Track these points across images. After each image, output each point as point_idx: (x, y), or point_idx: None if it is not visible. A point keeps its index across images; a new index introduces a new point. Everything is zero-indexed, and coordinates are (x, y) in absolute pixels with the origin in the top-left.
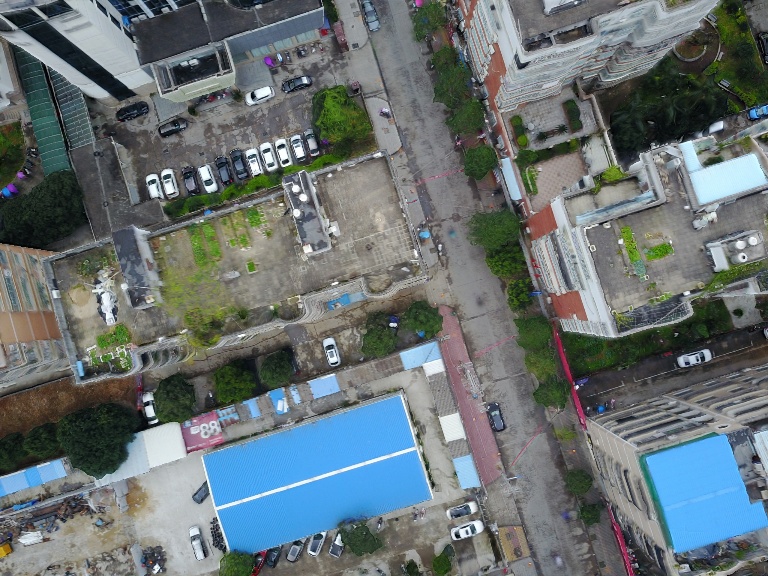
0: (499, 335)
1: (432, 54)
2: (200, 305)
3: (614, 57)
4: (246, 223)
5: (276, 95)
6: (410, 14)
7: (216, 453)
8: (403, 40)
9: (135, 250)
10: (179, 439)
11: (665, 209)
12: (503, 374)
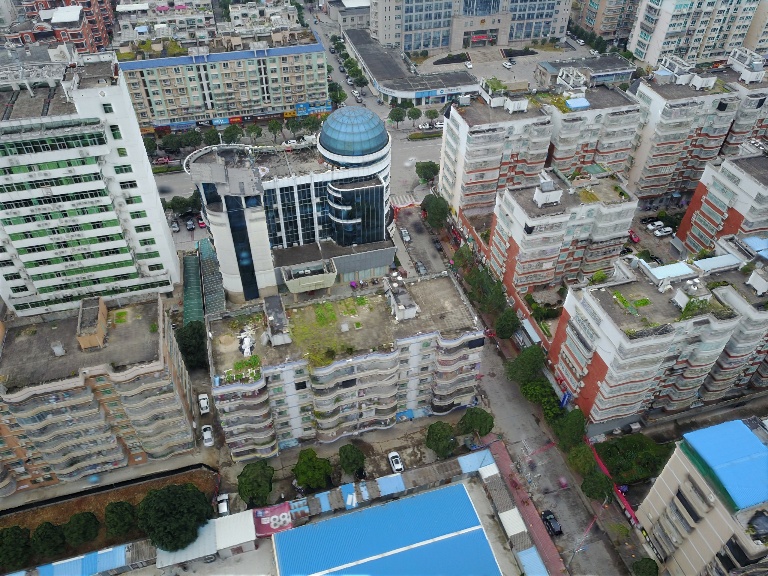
0: (541, 456)
1: (463, 287)
2: (320, 340)
3: (584, 258)
4: (355, 304)
5: None
6: None
7: (287, 532)
8: None
9: (279, 306)
10: (250, 524)
11: (638, 284)
12: (550, 488)
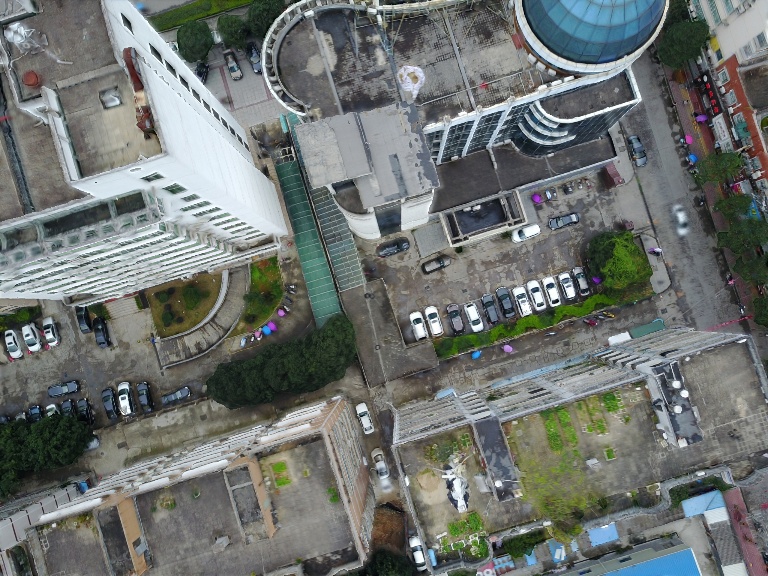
0: None
1: (700, 190)
2: (564, 496)
3: None
4: (602, 407)
5: (541, 231)
6: (677, 149)
7: None
8: (670, 175)
9: (500, 442)
10: None
11: None
12: None
